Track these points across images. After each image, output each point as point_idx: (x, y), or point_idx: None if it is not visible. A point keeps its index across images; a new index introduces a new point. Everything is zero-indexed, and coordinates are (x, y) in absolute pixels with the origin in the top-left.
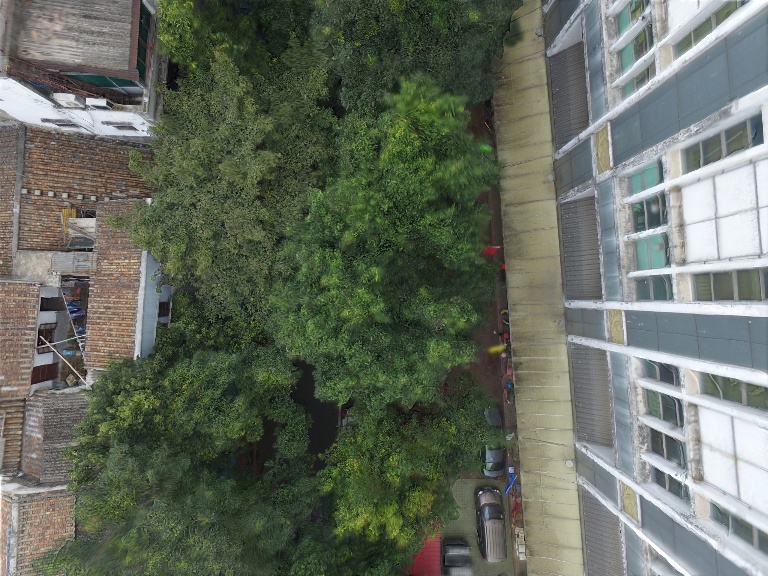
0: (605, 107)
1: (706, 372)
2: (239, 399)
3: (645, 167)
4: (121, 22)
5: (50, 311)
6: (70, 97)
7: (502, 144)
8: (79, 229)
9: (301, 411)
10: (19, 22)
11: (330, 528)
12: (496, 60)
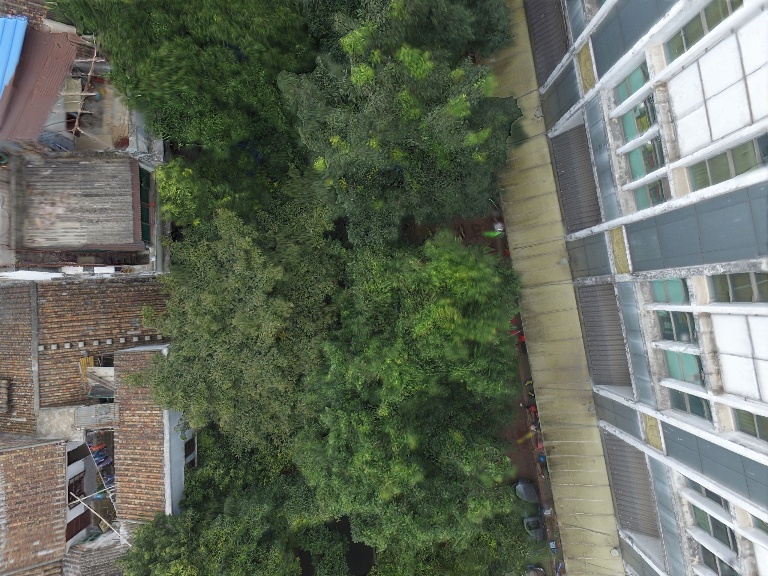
0: (618, 209)
1: (760, 518)
2: (275, 550)
3: (667, 278)
4: (122, 196)
5: (77, 461)
6: (78, 269)
7: (511, 225)
8: (98, 379)
9: (337, 538)
10: (22, 212)
11: None
12: None
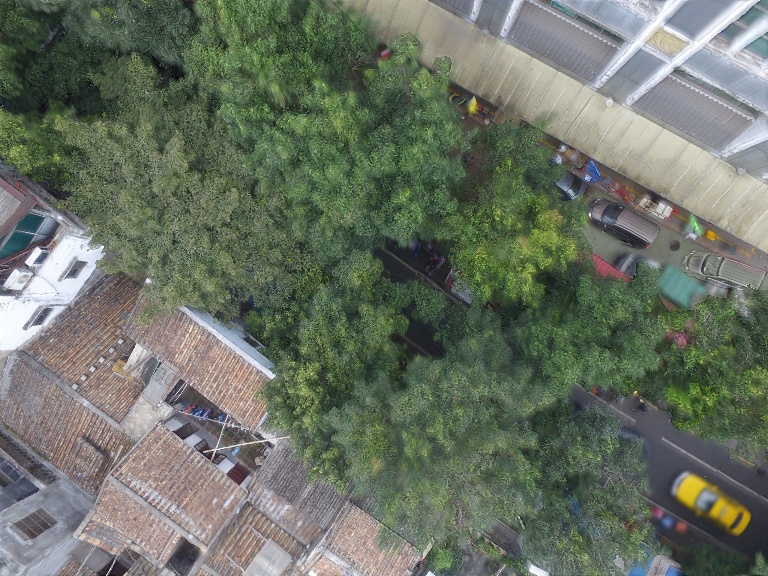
0: None
1: None
2: (361, 308)
3: None
4: None
5: (190, 436)
6: (15, 274)
7: None
8: (136, 364)
9: (411, 283)
10: None
11: (524, 315)
12: None
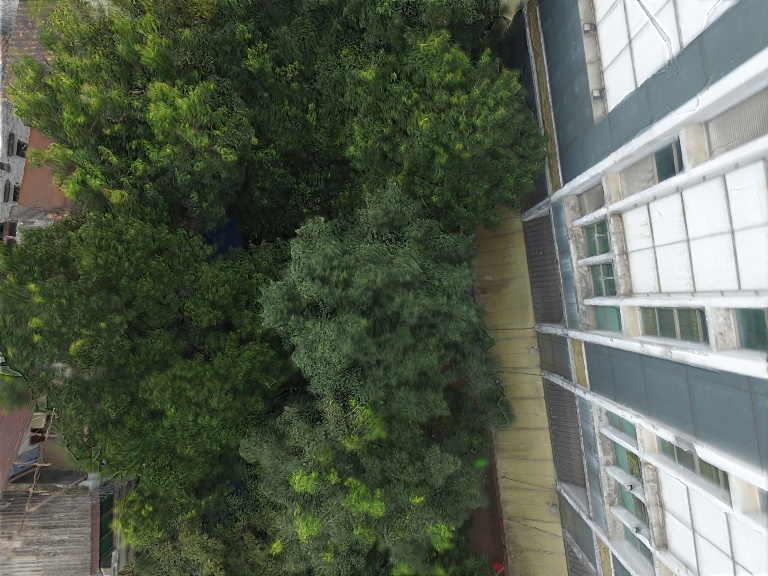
0: (605, 525)
1: None
2: None
3: None
4: (81, 527)
5: None
6: None
7: (500, 452)
8: None
9: None
10: None
11: None
12: (489, 358)
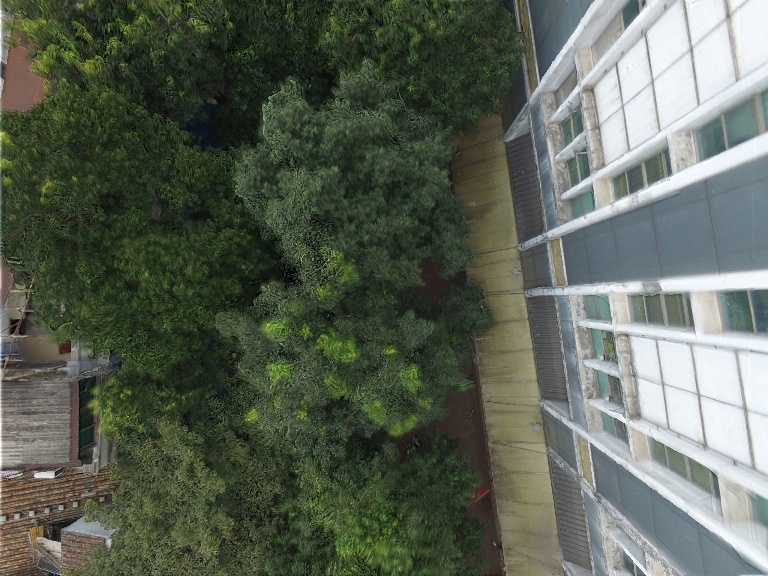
0: (584, 419)
1: None
2: None
3: None
4: (60, 413)
5: None
6: (18, 474)
7: (485, 377)
8: (46, 553)
9: None
10: None
11: None
12: (474, 285)
